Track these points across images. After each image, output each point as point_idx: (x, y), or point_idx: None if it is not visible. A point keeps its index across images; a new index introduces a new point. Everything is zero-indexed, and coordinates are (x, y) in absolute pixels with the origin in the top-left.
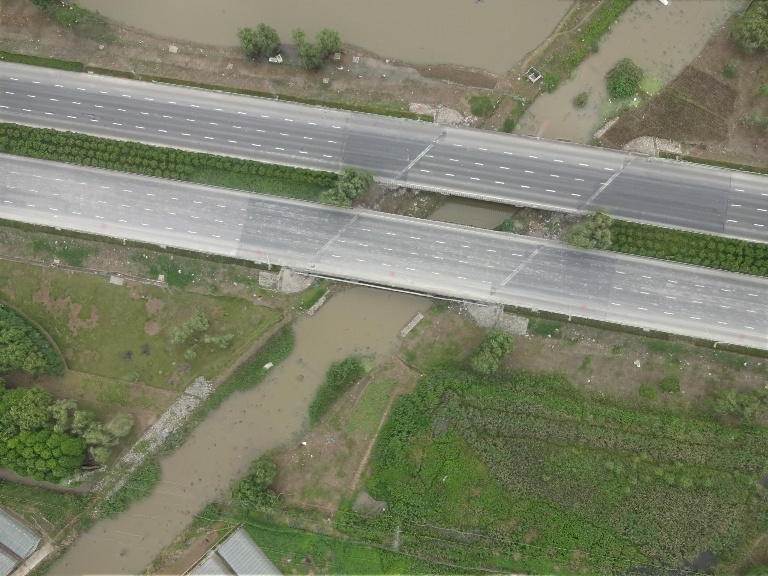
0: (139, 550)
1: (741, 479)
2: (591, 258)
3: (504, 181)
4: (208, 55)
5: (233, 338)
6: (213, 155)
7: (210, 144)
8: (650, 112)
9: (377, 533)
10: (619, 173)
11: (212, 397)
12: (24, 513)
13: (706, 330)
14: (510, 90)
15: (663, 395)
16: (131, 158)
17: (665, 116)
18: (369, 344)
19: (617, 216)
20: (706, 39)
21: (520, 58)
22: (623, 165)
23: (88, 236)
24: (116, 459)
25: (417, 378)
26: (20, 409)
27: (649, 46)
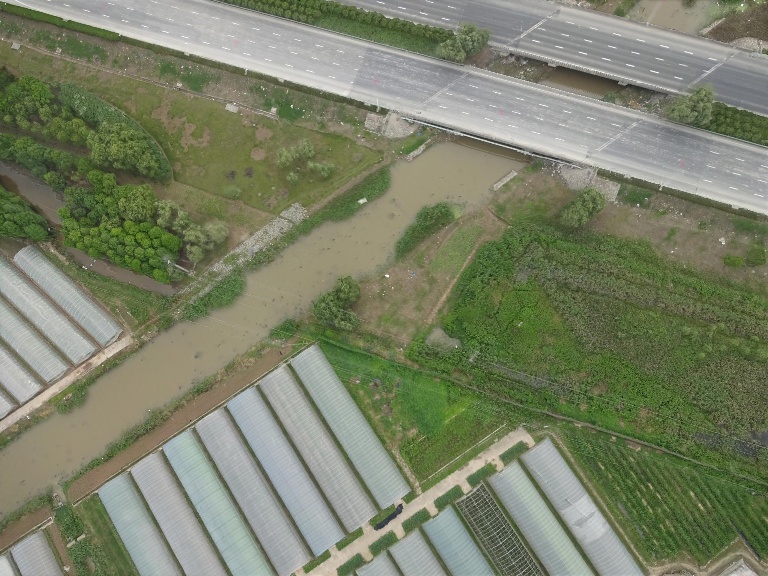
0: (213, 355)
1: None
2: (687, 136)
3: (610, 58)
4: None
5: (333, 171)
6: None
7: None
8: (756, 17)
9: (448, 365)
10: (722, 63)
11: (305, 222)
12: (111, 305)
13: None
14: None
15: (745, 274)
16: None
17: None
18: (461, 194)
19: (716, 101)
20: None
21: None
22: (727, 57)
23: (213, 63)
24: (205, 267)
25: (504, 229)
26: (128, 201)
27: None
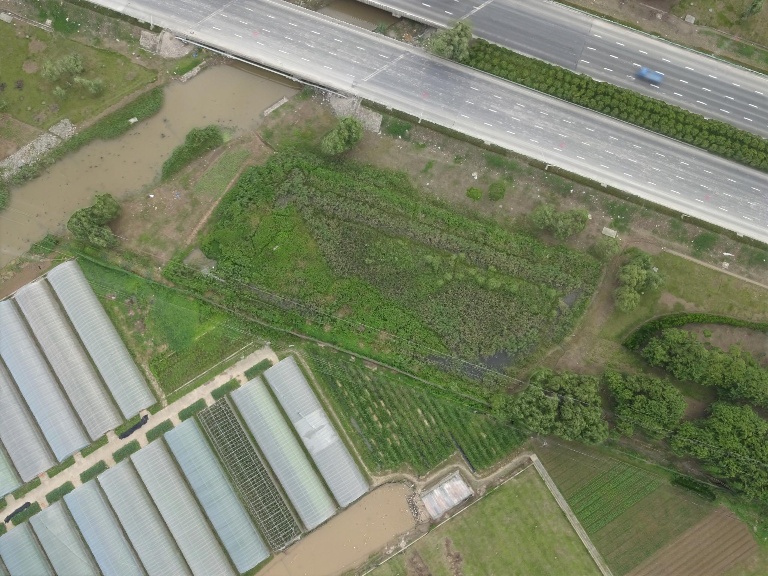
0: None
1: (547, 292)
2: (450, 71)
3: None
4: None
5: (105, 88)
6: None
7: None
8: None
9: (201, 285)
10: (492, 1)
11: (73, 139)
12: None
13: (541, 153)
14: None
15: (493, 208)
16: None
17: None
18: (232, 118)
19: (482, 38)
20: None
21: None
22: None
23: None
24: None
25: (270, 154)
26: None
27: None
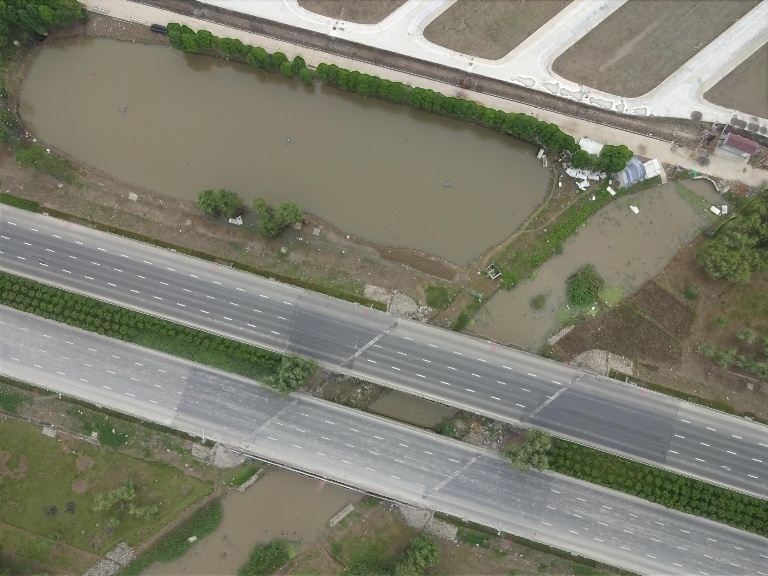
0: None
1: None
2: (528, 473)
3: (450, 382)
4: (168, 207)
5: (160, 507)
6: (158, 320)
7: (158, 304)
8: (606, 325)
9: None
10: (566, 388)
11: (132, 565)
12: None
13: (634, 562)
14: (468, 284)
15: None
16: (75, 313)
17: (621, 331)
18: (296, 529)
19: (559, 433)
20: (672, 254)
21: (482, 251)
22: (571, 380)
23: (24, 385)
24: None
25: (340, 571)
26: None
27: (614, 254)
